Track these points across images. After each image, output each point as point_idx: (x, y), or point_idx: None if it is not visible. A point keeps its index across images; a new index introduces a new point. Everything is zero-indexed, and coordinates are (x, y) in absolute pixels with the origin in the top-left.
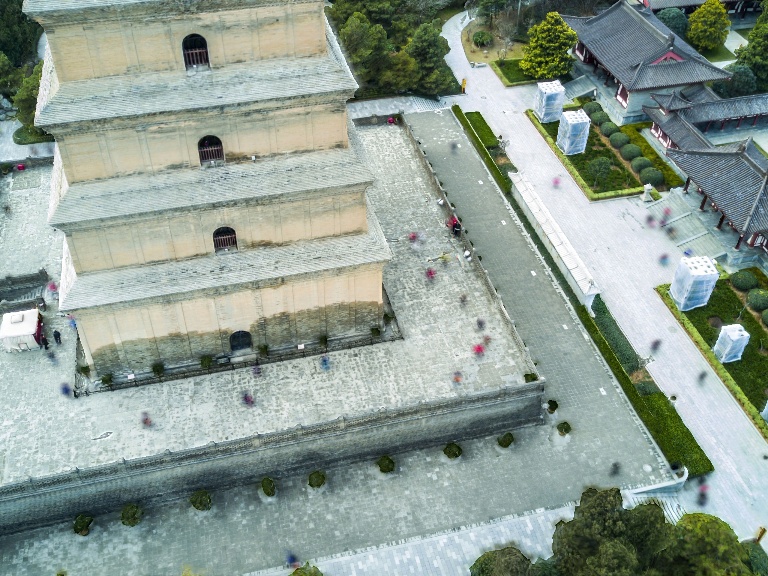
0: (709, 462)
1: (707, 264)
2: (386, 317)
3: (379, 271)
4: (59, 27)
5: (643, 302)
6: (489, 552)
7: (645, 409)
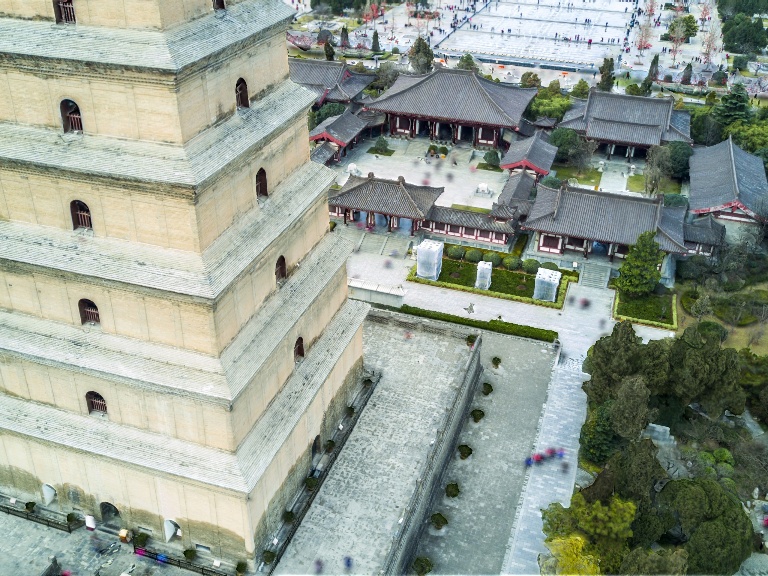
0: (553, 331)
1: (432, 242)
2: None
3: None
4: (201, 195)
5: (412, 290)
6: (592, 417)
7: (505, 328)
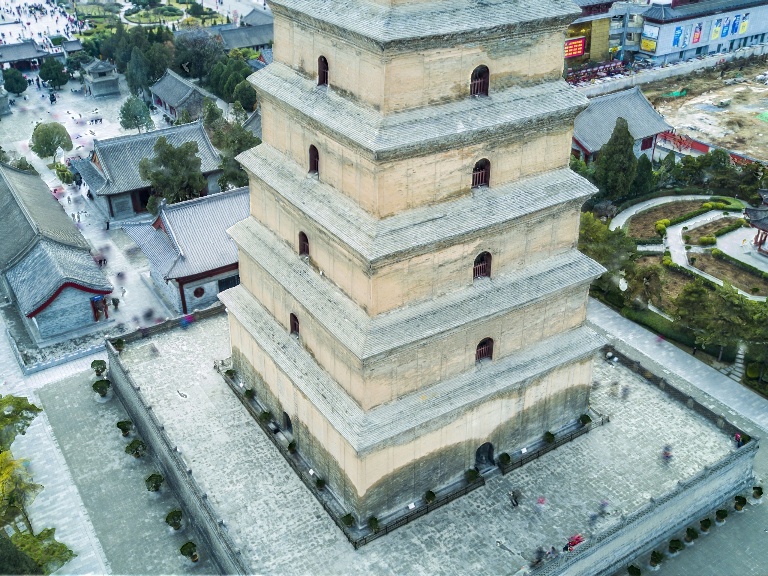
0: None
1: None
2: (372, 520)
3: (359, 458)
4: None
5: None
6: None
7: None
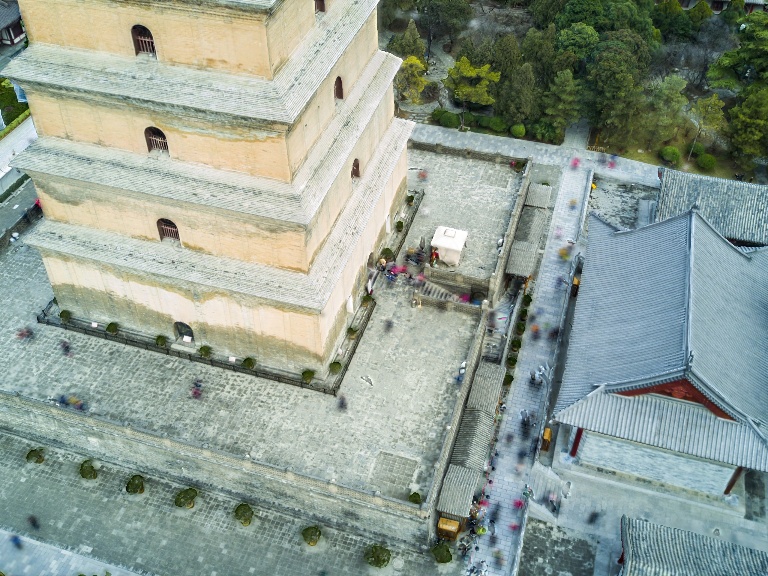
0: None
1: None
2: None
3: None
4: None
5: None
6: None
7: None
